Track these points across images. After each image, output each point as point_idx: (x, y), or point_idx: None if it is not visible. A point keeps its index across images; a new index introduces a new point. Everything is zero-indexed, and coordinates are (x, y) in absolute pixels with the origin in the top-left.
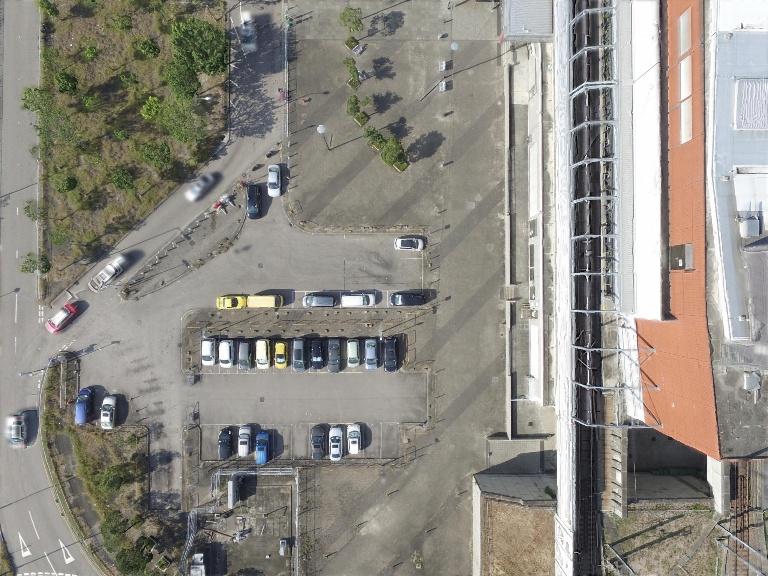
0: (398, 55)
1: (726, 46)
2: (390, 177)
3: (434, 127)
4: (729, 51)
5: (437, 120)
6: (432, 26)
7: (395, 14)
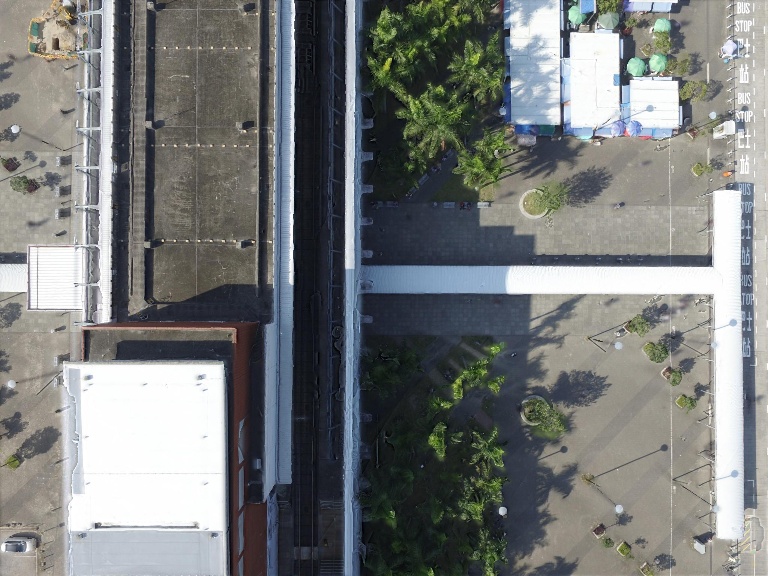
0: (14, 348)
1: (80, 547)
2: (4, 473)
3: (50, 422)
4: (84, 551)
5: (53, 415)
6: (49, 318)
7: (12, 306)
